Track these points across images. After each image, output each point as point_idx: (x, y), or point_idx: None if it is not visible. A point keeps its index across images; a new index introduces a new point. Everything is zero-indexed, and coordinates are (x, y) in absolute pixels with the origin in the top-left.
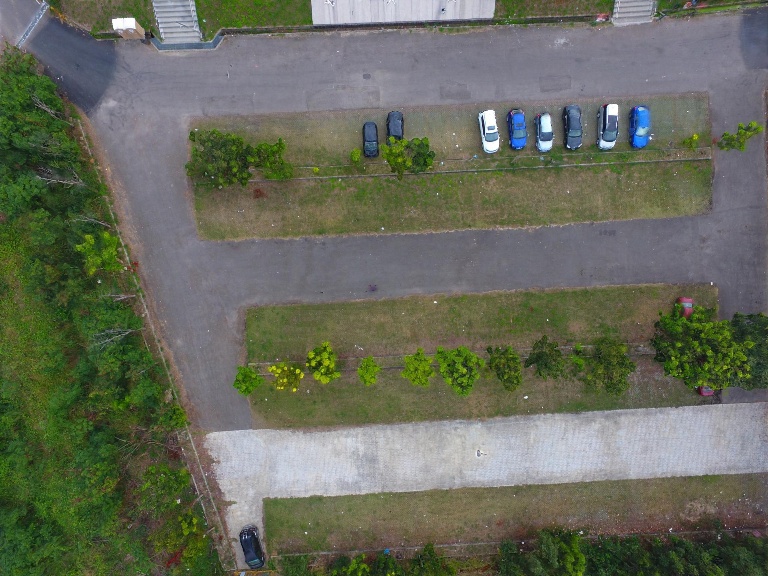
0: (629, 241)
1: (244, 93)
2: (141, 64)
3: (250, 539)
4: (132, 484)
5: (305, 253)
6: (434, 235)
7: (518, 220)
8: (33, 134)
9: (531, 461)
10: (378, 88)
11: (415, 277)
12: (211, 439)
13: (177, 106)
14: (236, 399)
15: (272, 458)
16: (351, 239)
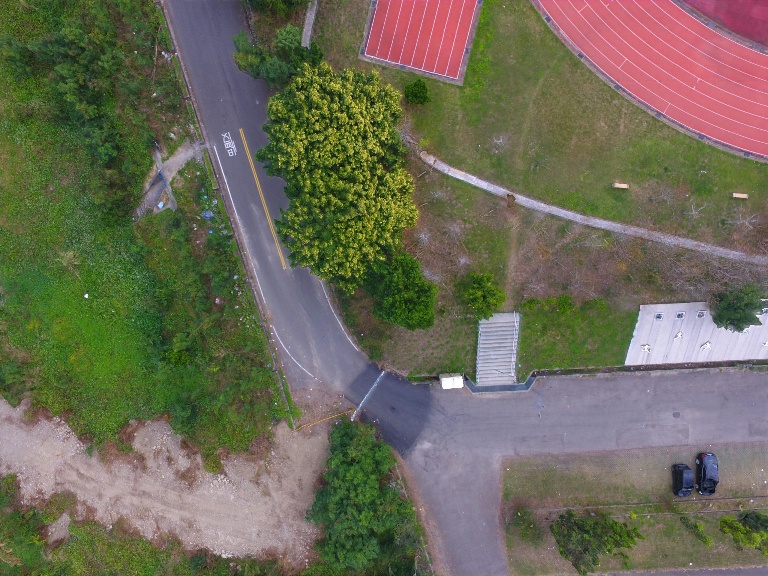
0: None
1: (555, 433)
2: (455, 406)
3: None
4: None
5: None
6: (742, 570)
7: None
8: (389, 520)
9: None
10: (687, 426)
11: None
12: None
13: (490, 446)
14: None
15: None
16: (659, 574)
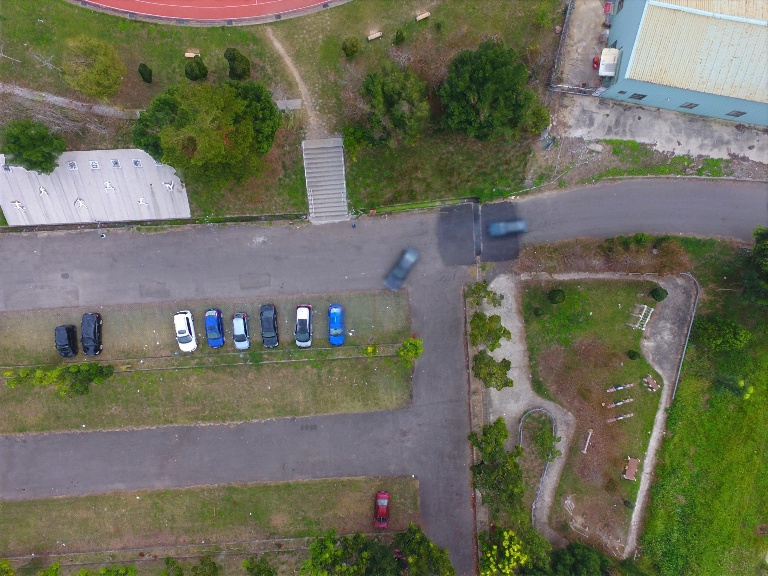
0: (330, 435)
1: None
2: None
3: None
4: None
5: (6, 451)
6: (136, 432)
7: (219, 416)
8: None
9: None
10: (77, 287)
11: (117, 473)
12: None
13: None
14: None
15: None
16: (52, 436)
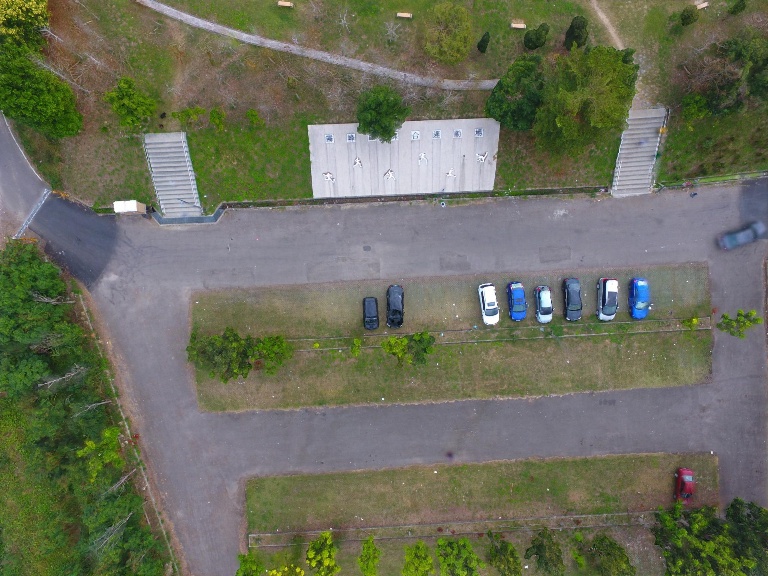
0: (629, 410)
1: (245, 266)
2: (142, 238)
3: None
4: None
5: (305, 424)
6: (434, 405)
7: (518, 390)
8: (35, 331)
9: None
10: (378, 260)
11: (415, 447)
12: None
13: (178, 279)
14: (236, 570)
15: None
16: (351, 410)
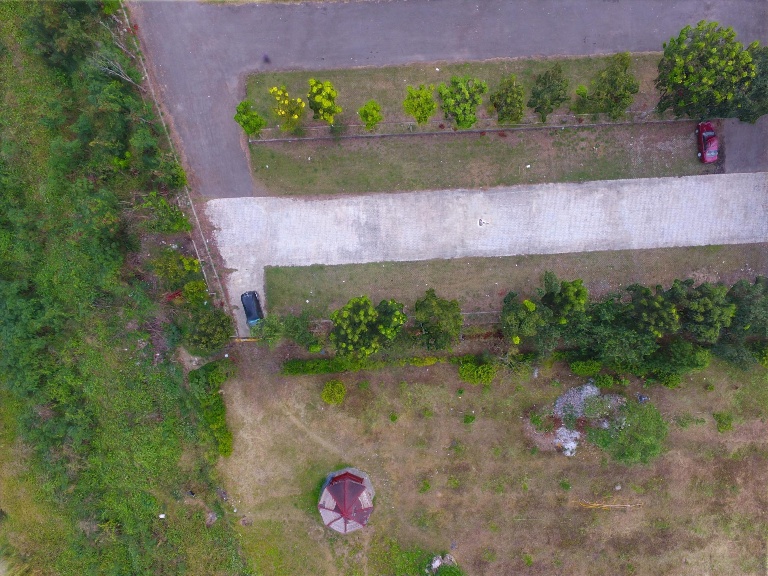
0: (633, 8)
1: None
2: None
3: (251, 297)
4: (133, 255)
5: (306, 18)
6: (436, 1)
7: None
8: None
9: (533, 230)
10: None
11: (417, 44)
12: (212, 206)
13: None
14: (237, 166)
15: (273, 226)
16: (352, 4)
